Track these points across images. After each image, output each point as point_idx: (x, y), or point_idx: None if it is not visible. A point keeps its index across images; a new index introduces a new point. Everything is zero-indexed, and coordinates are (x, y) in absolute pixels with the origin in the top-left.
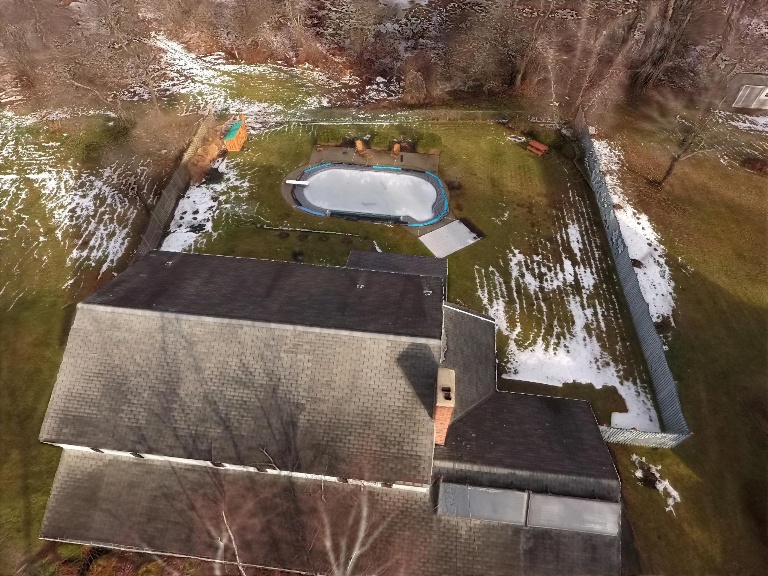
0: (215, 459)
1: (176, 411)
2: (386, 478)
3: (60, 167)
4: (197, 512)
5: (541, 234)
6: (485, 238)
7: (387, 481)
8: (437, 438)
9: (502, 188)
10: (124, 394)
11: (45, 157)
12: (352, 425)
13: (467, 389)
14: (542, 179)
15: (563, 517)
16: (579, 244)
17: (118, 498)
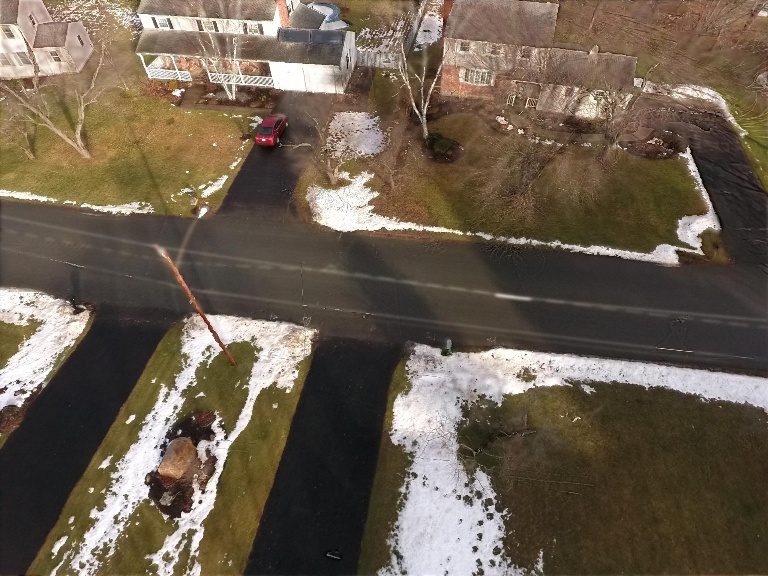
0: (199, 16)
1: (186, 4)
2: (258, 19)
3: (123, 8)
4: (193, 44)
5: (383, 24)
6: (353, 25)
7: (258, 20)
8: (282, 21)
9: (371, 10)
10: (167, 0)
11: (114, 4)
12: (248, 6)
13: (304, 25)
14: (396, 7)
15: (323, 39)
16: (402, 26)
17: (164, 41)
